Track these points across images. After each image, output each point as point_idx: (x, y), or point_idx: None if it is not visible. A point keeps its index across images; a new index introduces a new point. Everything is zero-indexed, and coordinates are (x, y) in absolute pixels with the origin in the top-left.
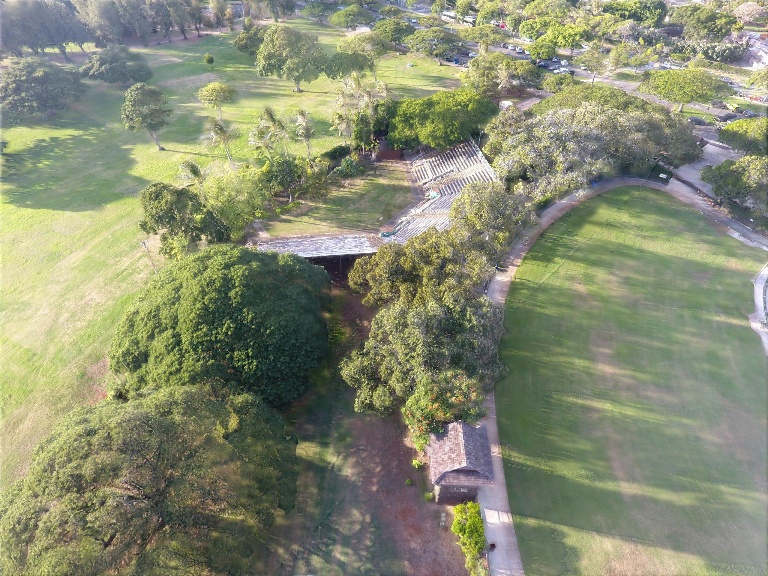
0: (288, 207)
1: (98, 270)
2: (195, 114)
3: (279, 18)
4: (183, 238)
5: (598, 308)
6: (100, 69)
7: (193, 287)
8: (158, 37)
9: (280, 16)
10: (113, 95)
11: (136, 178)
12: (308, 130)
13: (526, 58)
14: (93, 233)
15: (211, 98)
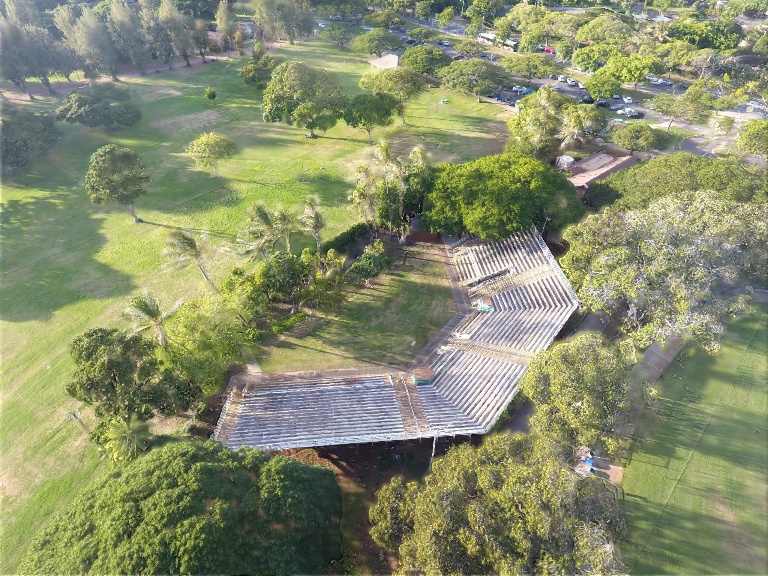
0: (289, 323)
1: (21, 430)
2: (187, 168)
3: (295, 40)
4: (123, 423)
5: (763, 562)
6: (79, 111)
7: (111, 569)
8: (158, 63)
9: (296, 38)
10: (95, 140)
11: (100, 266)
12: (318, 219)
13: (582, 94)
14: (28, 360)
15: (203, 155)
